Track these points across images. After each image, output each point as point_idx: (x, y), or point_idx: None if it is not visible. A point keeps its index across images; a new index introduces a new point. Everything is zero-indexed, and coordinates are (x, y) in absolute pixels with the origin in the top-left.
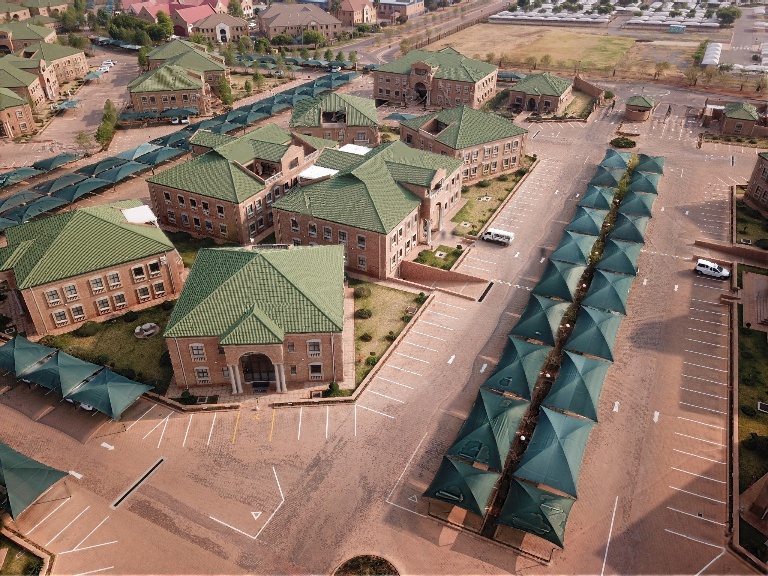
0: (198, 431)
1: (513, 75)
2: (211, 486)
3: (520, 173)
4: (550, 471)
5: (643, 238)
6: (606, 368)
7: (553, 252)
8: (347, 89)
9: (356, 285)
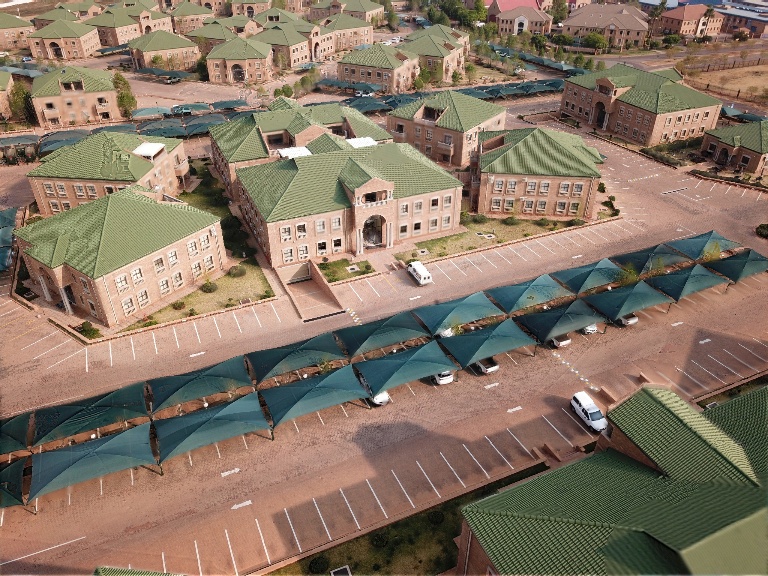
0: None
1: (759, 118)
2: None
3: (569, 223)
4: (48, 470)
5: (549, 337)
6: (251, 428)
7: None
8: (554, 97)
9: (247, 264)
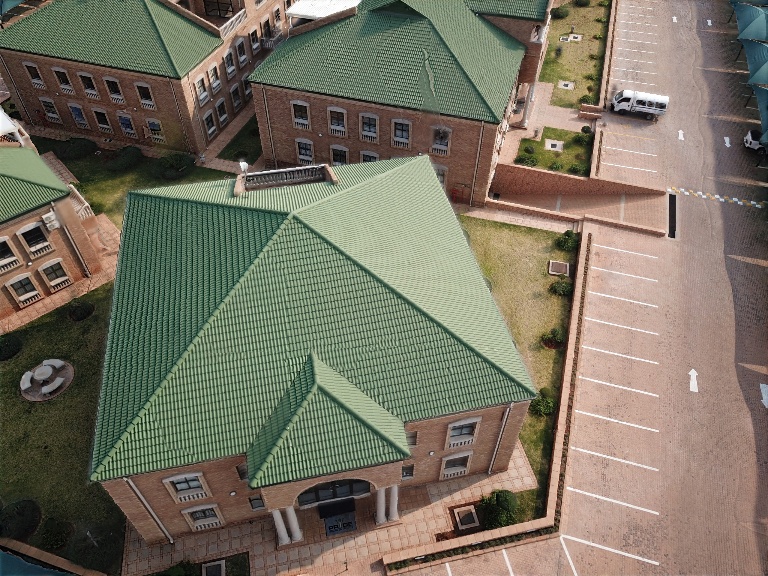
0: None
1: None
2: None
3: None
4: None
5: None
6: None
7: None
8: None
9: None
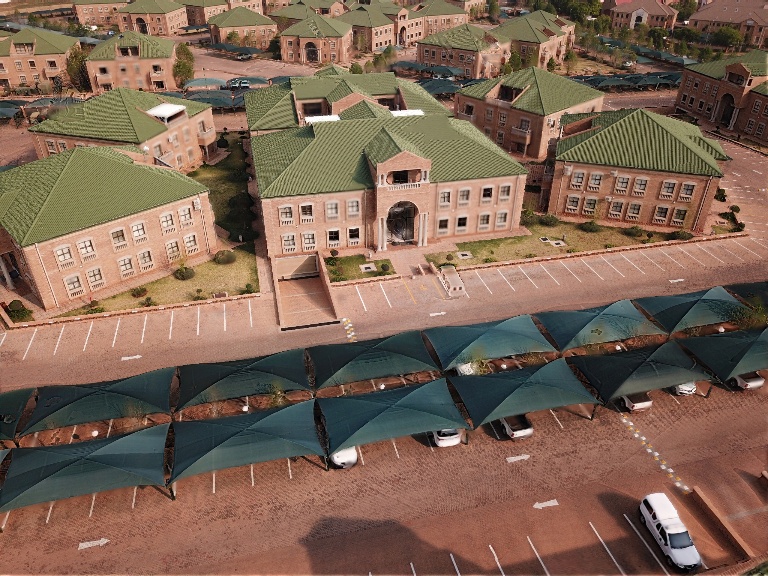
0: None
1: None
2: None
3: (670, 236)
4: None
5: (617, 394)
6: (134, 481)
7: None
8: (669, 93)
9: (241, 250)
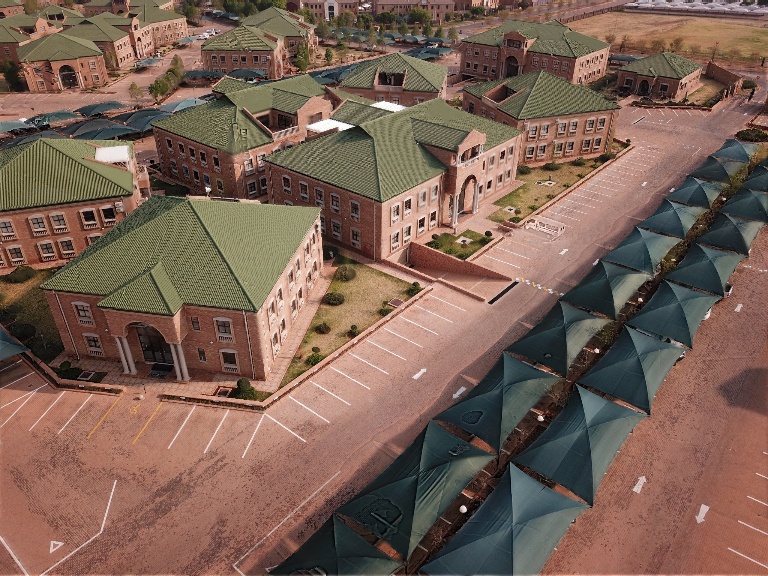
0: (58, 414)
1: (631, 57)
2: (27, 491)
3: (603, 159)
4: None
5: (748, 248)
6: (633, 422)
7: (609, 252)
8: None
9: (342, 264)
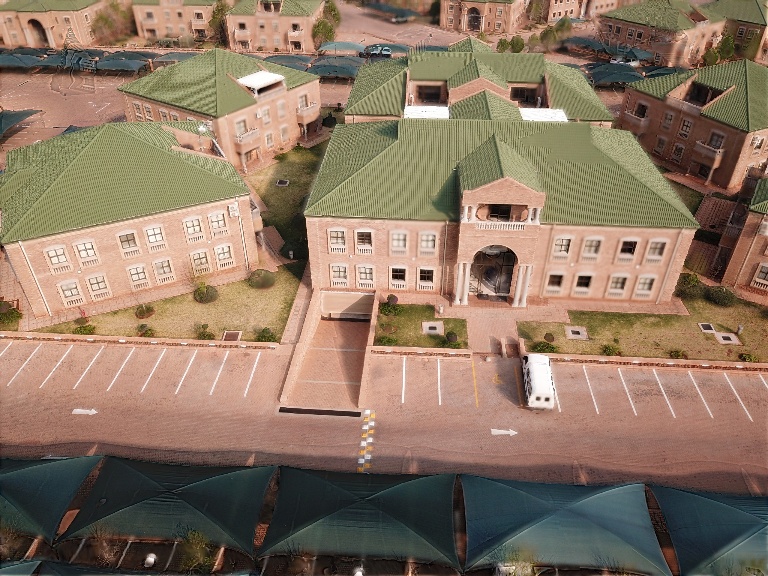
0: None
1: None
2: None
3: None
4: None
5: None
6: None
7: None
8: None
9: (286, 270)
